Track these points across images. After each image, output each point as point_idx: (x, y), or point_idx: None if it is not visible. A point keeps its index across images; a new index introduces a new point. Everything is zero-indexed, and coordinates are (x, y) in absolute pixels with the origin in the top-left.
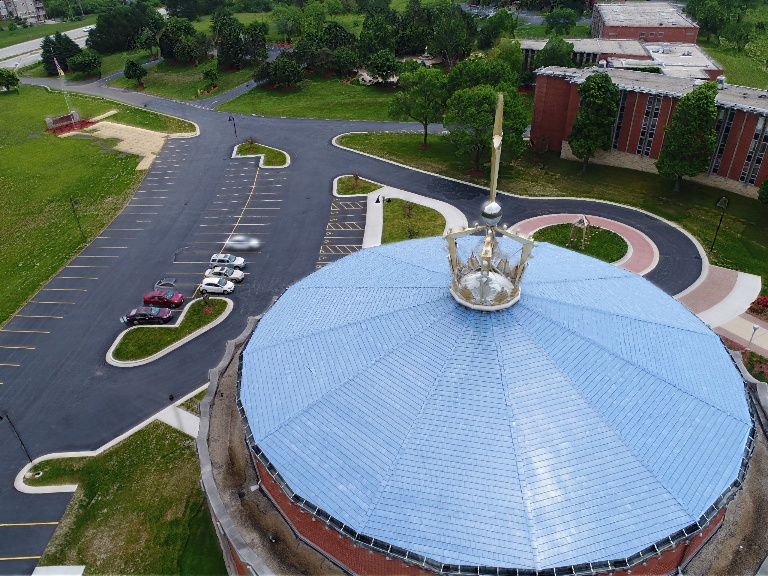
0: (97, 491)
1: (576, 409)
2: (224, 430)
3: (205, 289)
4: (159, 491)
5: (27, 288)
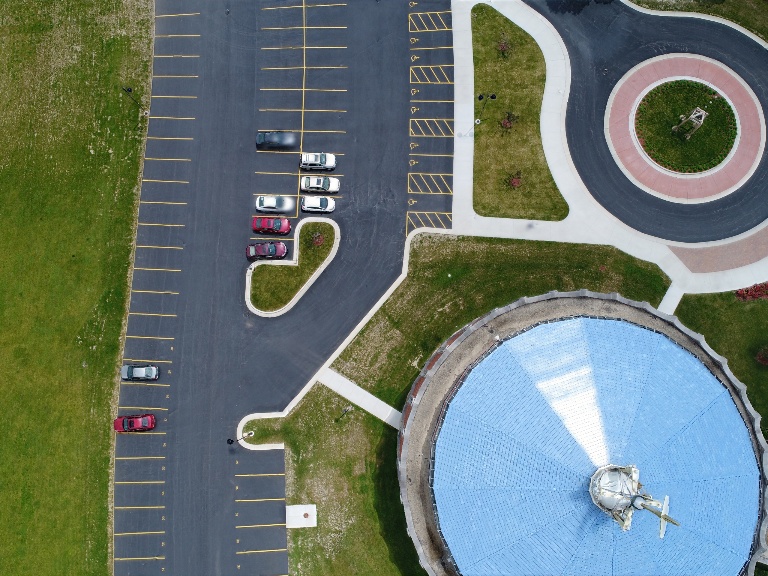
0: (300, 449)
1: (652, 575)
2: (420, 513)
3: (308, 210)
4: (343, 451)
5: (124, 199)
